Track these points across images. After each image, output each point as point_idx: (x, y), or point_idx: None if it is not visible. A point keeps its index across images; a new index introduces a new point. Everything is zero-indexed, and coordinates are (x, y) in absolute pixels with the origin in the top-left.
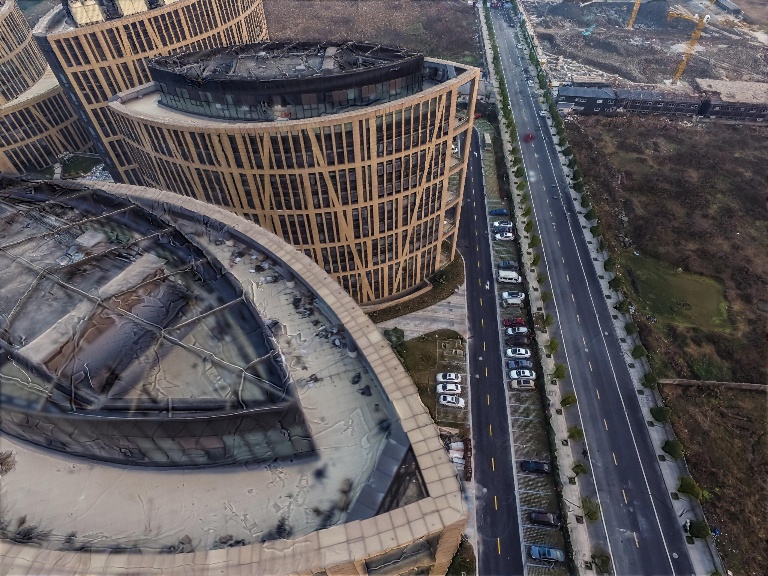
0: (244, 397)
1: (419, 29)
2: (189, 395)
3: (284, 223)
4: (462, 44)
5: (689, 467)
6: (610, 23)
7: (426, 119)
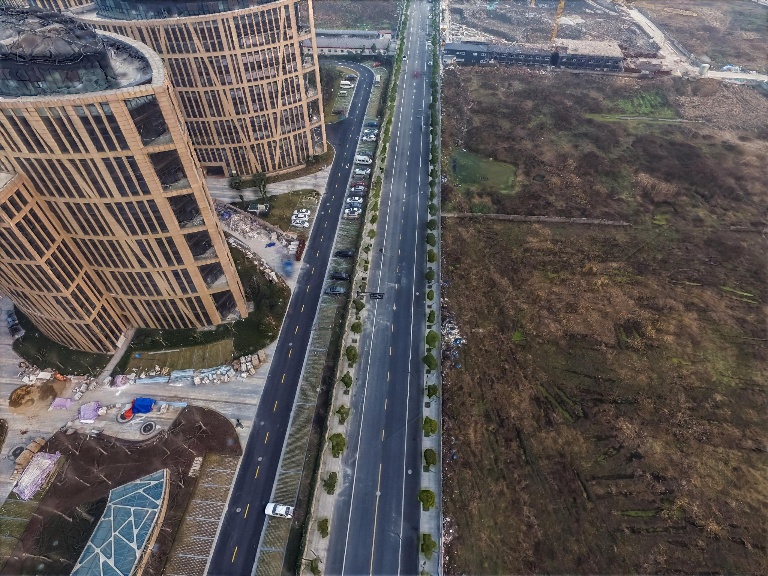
0: (83, 50)
1: (345, 0)
2: (64, 57)
3: (183, 99)
4: (383, 14)
5: (445, 255)
6: (518, 2)
7: (272, 24)
